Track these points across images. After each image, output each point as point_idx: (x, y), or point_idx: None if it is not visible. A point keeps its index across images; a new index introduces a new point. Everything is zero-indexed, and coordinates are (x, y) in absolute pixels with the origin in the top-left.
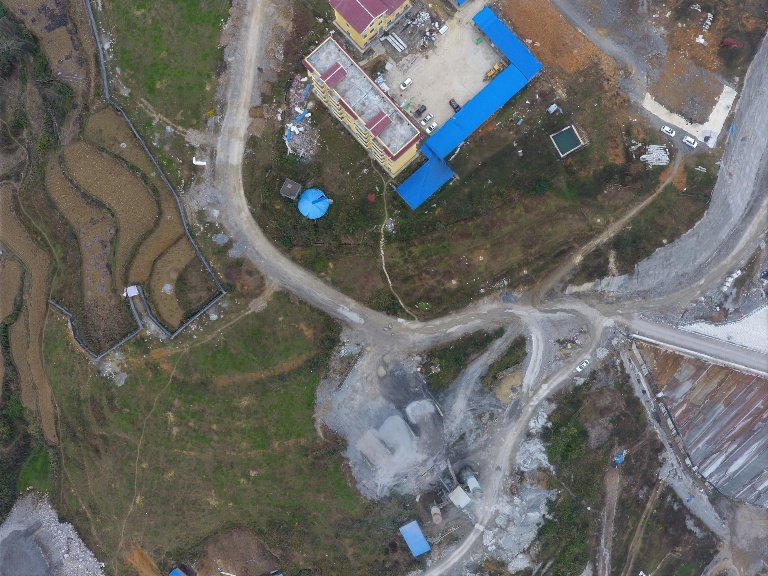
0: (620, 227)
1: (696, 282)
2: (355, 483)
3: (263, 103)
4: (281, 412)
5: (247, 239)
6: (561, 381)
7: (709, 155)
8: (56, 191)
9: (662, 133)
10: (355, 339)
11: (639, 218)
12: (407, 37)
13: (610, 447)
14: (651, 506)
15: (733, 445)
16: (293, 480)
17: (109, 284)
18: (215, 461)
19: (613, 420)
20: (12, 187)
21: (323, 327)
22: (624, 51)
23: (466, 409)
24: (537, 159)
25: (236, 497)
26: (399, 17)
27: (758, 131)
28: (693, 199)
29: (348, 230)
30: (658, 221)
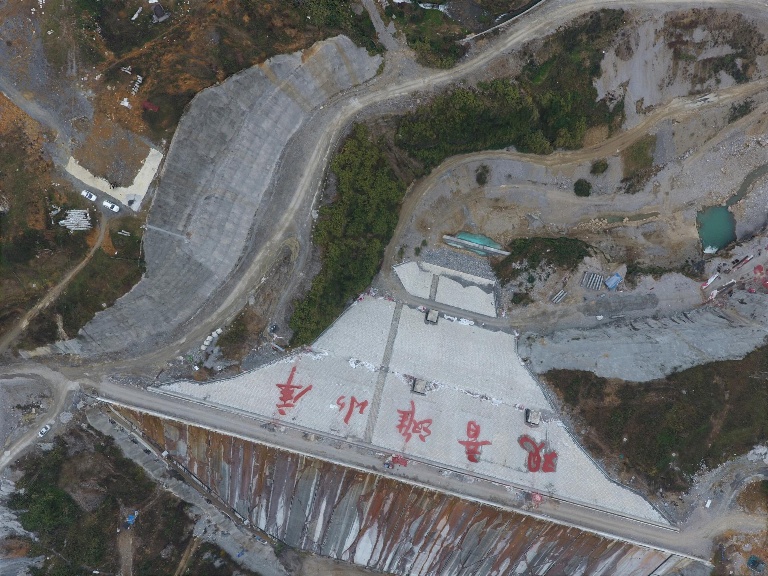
0: (59, 291)
1: (176, 341)
2: None
3: None
4: None
5: None
6: (24, 447)
7: (134, 219)
8: None
9: (85, 197)
10: None
11: (74, 282)
12: None
13: (112, 509)
14: (184, 564)
15: (263, 500)
16: None
17: None
18: None
19: (98, 483)
20: None
21: None
22: (49, 115)
23: None
24: None
25: None
26: None
27: (241, 187)
28: (126, 262)
29: None
30: (90, 285)
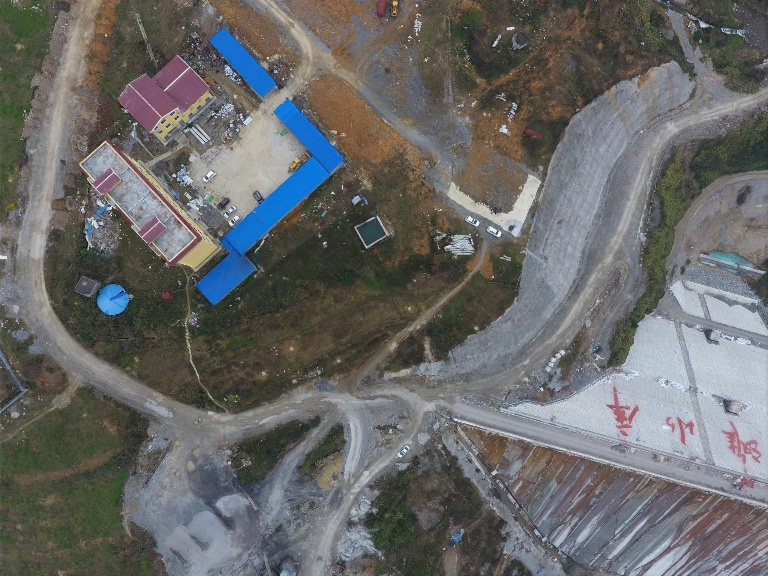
0: (432, 315)
1: (520, 363)
2: None
3: (66, 195)
4: (88, 510)
5: (49, 335)
6: (383, 467)
7: (514, 244)
8: None
9: (467, 223)
10: (163, 434)
11: (449, 306)
12: (211, 128)
13: (444, 527)
14: None
15: (575, 518)
16: None
17: None
18: (21, 562)
19: (442, 502)
20: None
21: (127, 423)
22: (429, 141)
23: (283, 500)
24: (342, 250)
25: None
26: (203, 109)
27: (580, 211)
28: (502, 287)
29: (149, 325)
30: (467, 309)
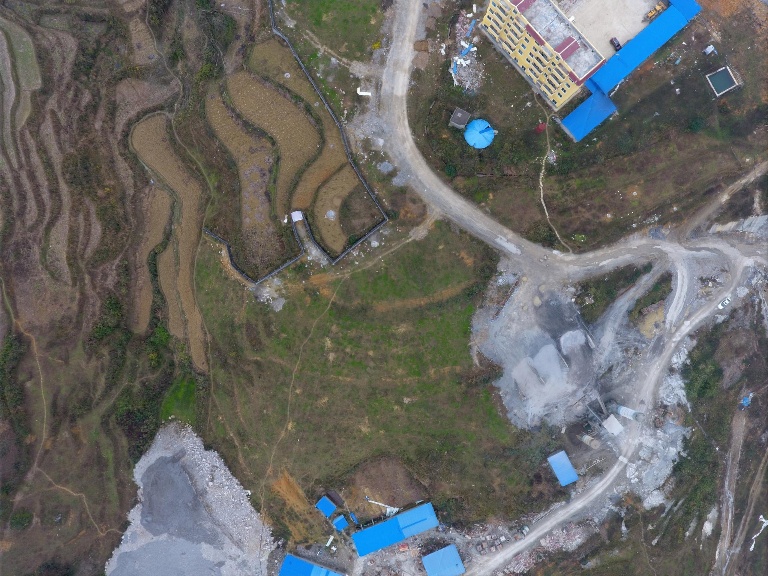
0: (767, 167)
1: None
2: (506, 412)
3: (427, 37)
4: (437, 340)
5: (410, 168)
6: (703, 318)
7: None
8: (216, 120)
9: None
10: (512, 269)
11: None
12: None
13: (739, 388)
14: None
15: None
16: (446, 408)
17: (267, 212)
18: (370, 387)
19: (747, 360)
20: (165, 117)
21: (483, 255)
22: None
23: (614, 342)
24: (694, 98)
25: (388, 424)
26: None
27: None
28: None
29: (512, 160)
30: None
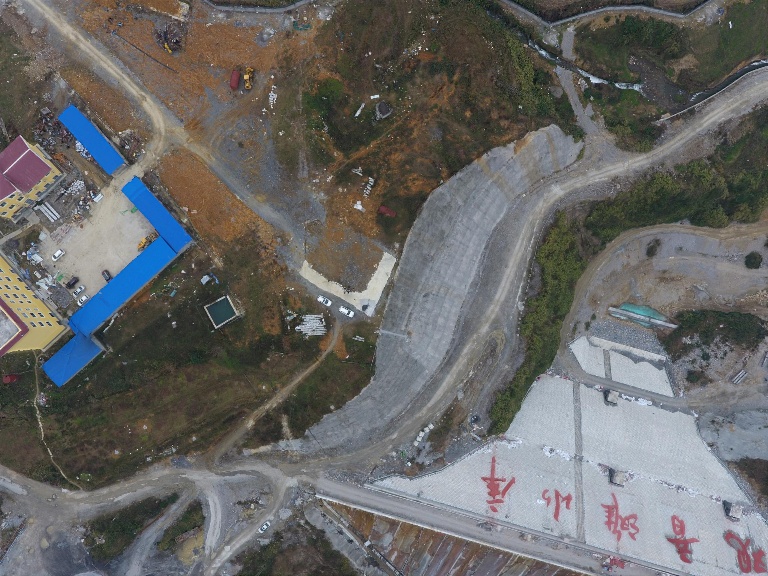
0: (287, 393)
1: (388, 436)
2: None
3: None
4: None
5: None
6: (244, 543)
7: (368, 324)
8: None
9: (319, 302)
10: (16, 511)
11: (304, 385)
12: (62, 206)
13: None
14: None
15: None
16: None
17: None
18: None
19: (309, 575)
20: None
21: None
22: (282, 218)
23: (141, 575)
24: (191, 331)
25: None
26: (53, 186)
27: (452, 281)
28: (357, 366)
29: None
30: (321, 389)
